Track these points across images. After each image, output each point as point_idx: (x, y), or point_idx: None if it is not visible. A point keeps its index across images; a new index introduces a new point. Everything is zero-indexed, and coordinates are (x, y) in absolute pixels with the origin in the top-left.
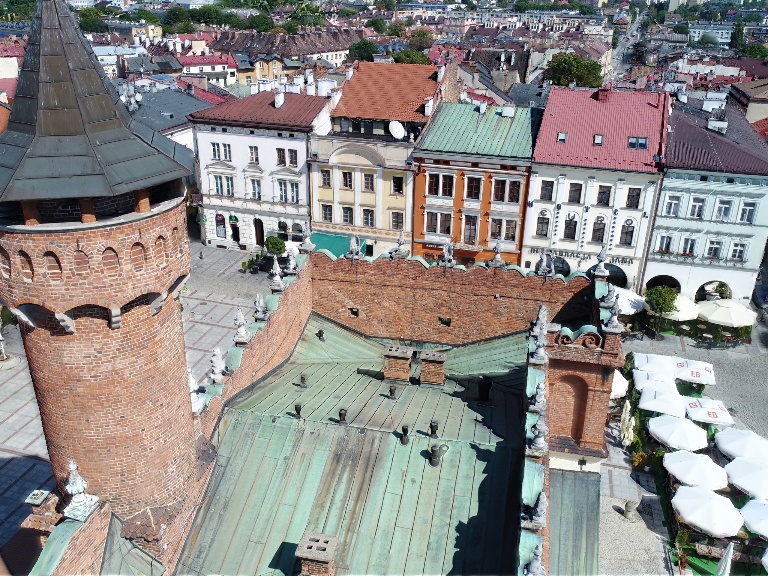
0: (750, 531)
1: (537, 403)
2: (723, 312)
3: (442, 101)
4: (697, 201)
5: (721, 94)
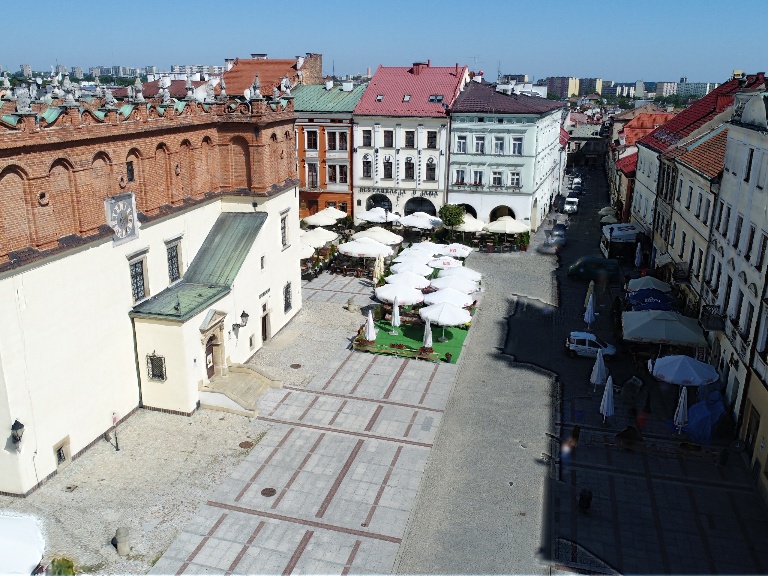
0: (425, 303)
1: (164, 102)
2: (501, 224)
3: (300, 84)
4: (479, 139)
5: (542, 87)
